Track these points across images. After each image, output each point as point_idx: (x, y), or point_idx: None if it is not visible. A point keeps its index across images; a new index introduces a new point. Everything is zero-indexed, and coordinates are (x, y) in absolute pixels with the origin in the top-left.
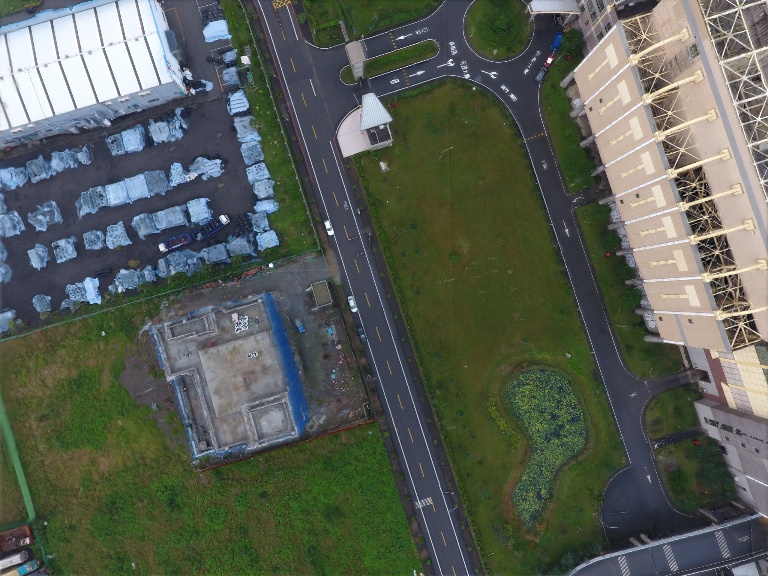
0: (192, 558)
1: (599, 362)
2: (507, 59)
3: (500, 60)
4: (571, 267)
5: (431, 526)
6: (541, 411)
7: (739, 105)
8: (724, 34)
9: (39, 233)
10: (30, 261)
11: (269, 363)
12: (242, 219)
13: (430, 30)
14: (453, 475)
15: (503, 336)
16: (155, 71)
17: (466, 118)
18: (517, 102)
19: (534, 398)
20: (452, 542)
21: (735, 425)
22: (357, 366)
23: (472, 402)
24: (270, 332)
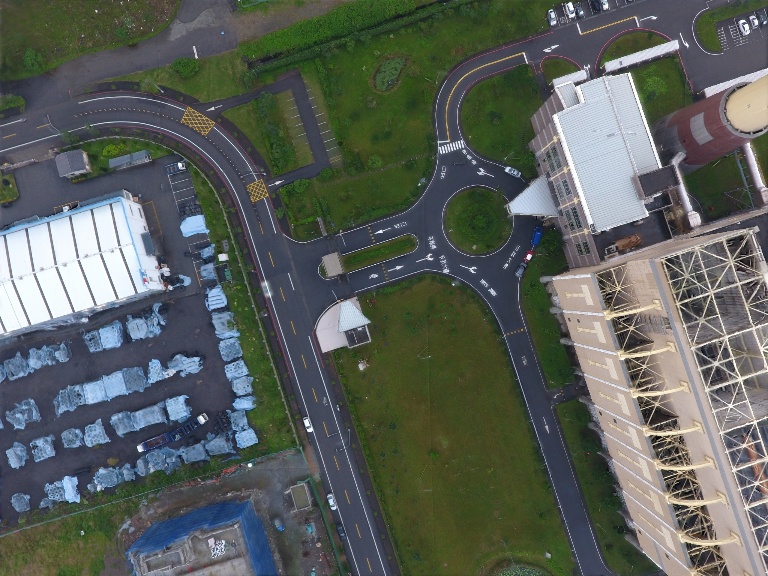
0: None
1: (579, 560)
2: (486, 254)
3: (479, 255)
4: (551, 464)
5: None
6: None
7: (711, 391)
8: (696, 319)
9: (17, 431)
10: (8, 461)
11: None
12: (221, 417)
13: (409, 224)
14: None
15: (483, 534)
16: (131, 281)
17: (445, 314)
18: (497, 297)
19: None
20: None
21: None
22: (337, 565)
23: None
24: (247, 557)
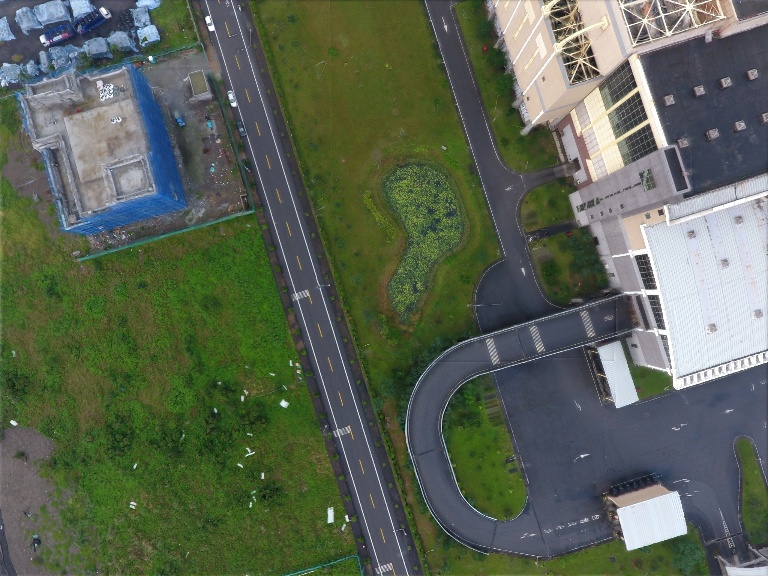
0: (71, 346)
1: (476, 156)
2: None
3: None
4: (449, 63)
5: (308, 318)
6: (418, 205)
7: None
8: None
9: None
10: None
11: (133, 129)
12: (123, 14)
13: None
14: (330, 268)
15: (381, 131)
16: None
17: None
18: None
19: (411, 193)
20: (328, 333)
21: (594, 194)
22: (236, 159)
23: (349, 196)
24: (134, 99)
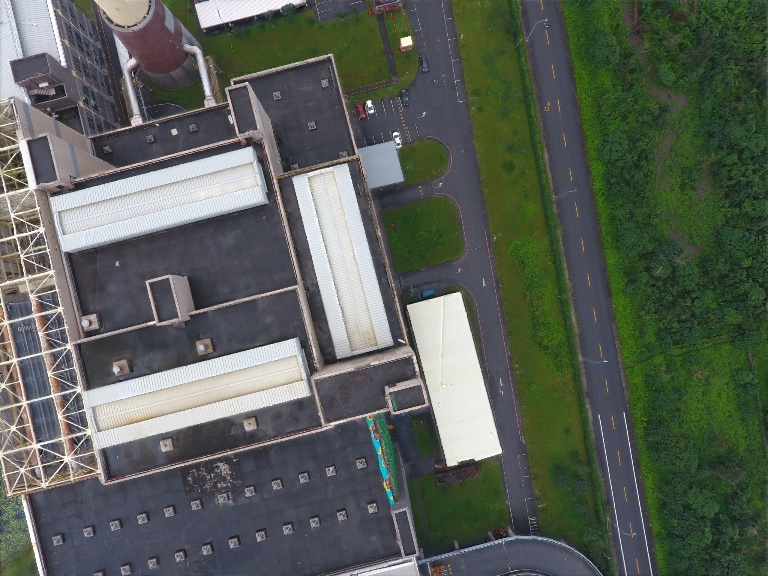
0: None
1: None
2: None
3: None
4: None
5: None
6: None
7: None
8: None
9: None
10: None
11: None
12: None
13: None
14: None
15: None
16: None
17: None
18: None
19: None
20: None
21: None
22: None
23: None
24: None
